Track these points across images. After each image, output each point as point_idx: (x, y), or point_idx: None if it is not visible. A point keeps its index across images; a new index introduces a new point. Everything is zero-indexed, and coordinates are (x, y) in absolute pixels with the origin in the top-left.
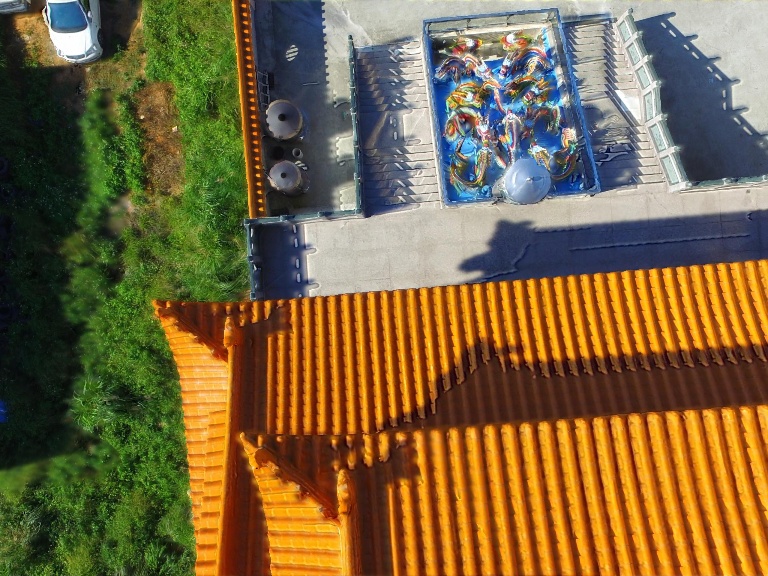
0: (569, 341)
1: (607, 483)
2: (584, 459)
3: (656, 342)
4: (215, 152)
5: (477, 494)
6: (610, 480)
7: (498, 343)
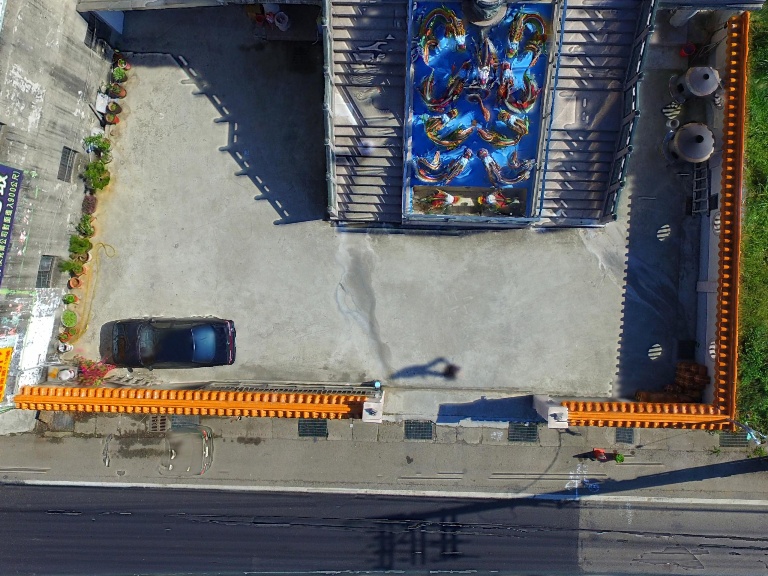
0: None
1: None
2: None
3: None
4: (765, 129)
5: None
6: None
7: None
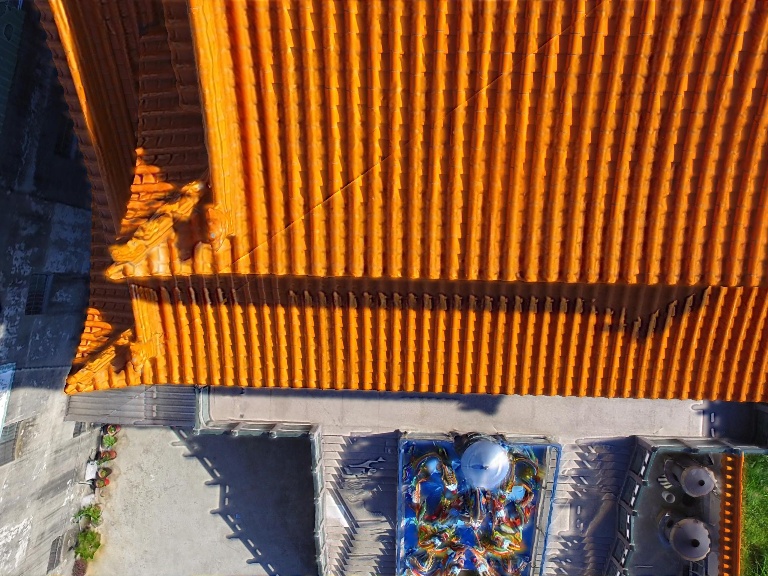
0: (545, 331)
1: (621, 216)
2: (639, 243)
3: (456, 322)
4: (762, 511)
5: (767, 216)
6: (618, 219)
7: (621, 337)
